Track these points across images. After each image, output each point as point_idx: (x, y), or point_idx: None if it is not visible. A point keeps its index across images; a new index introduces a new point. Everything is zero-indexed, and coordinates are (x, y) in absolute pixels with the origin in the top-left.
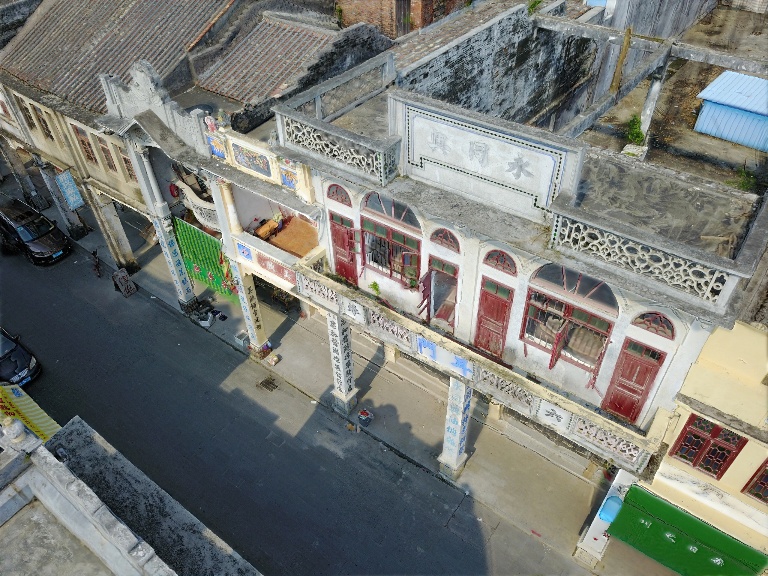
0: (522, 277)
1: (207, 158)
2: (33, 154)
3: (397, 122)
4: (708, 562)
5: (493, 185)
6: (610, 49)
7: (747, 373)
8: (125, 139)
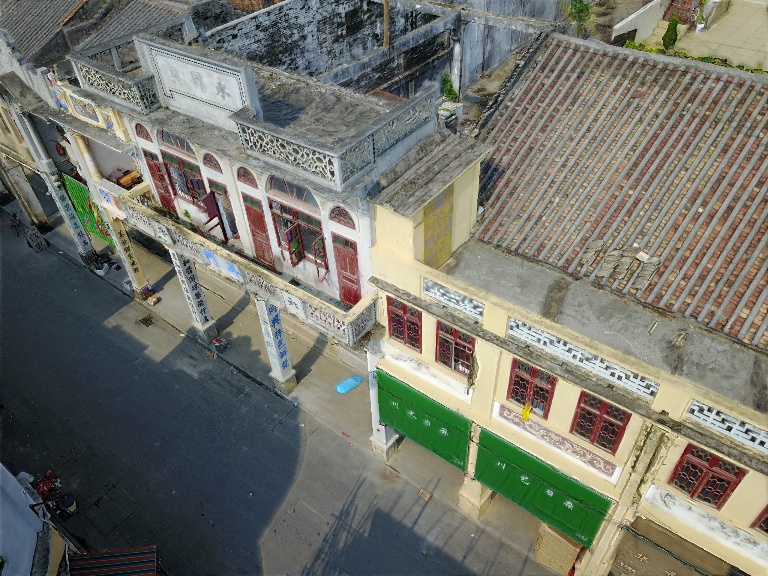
0: (261, 189)
1: (56, 110)
2: None
3: (147, 61)
4: (439, 433)
5: (214, 108)
6: (473, 25)
7: (404, 252)
8: (6, 101)
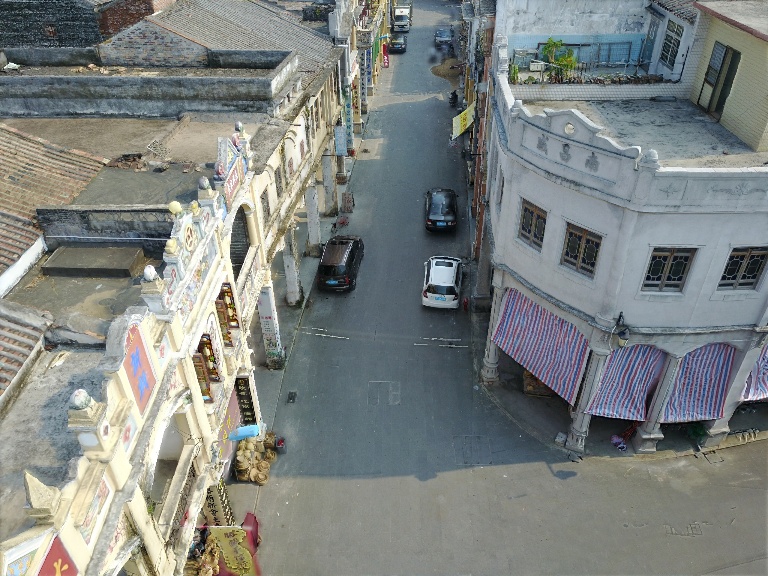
0: None
1: None
2: None
3: None
4: None
5: None
6: None
7: None
8: None
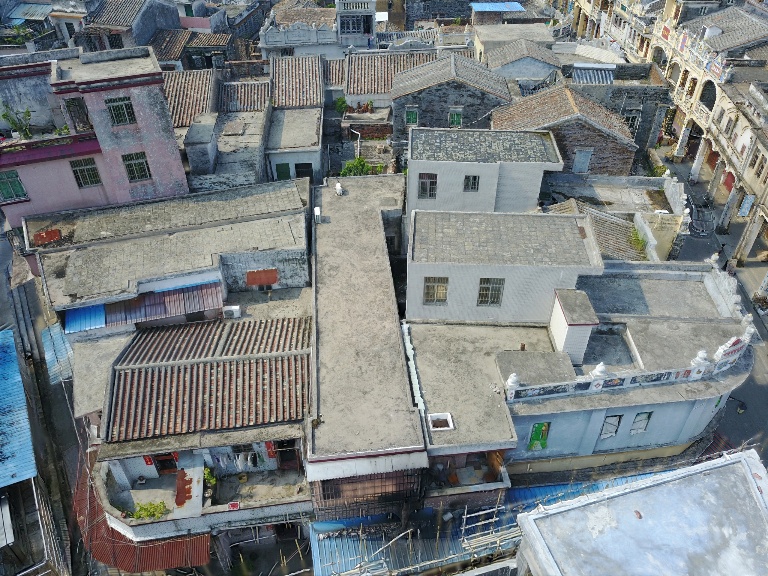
0: None
1: None
2: (737, 179)
3: None
4: None
5: None
6: None
7: None
8: None
